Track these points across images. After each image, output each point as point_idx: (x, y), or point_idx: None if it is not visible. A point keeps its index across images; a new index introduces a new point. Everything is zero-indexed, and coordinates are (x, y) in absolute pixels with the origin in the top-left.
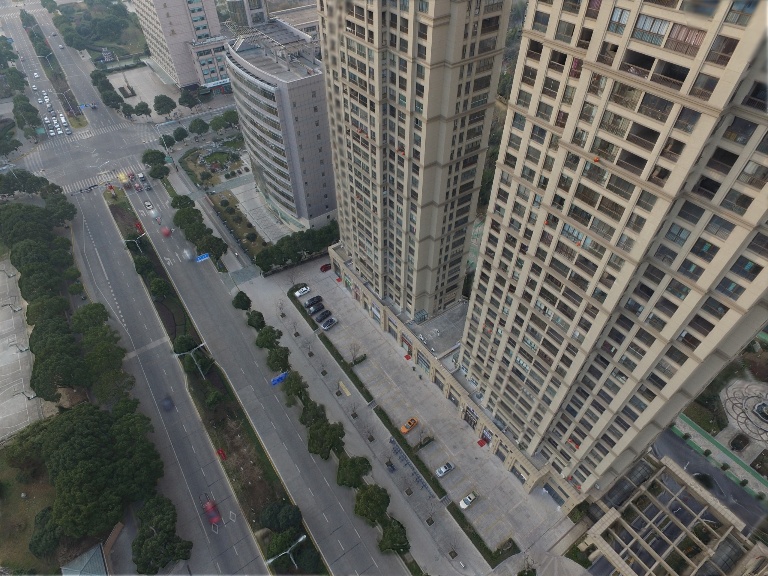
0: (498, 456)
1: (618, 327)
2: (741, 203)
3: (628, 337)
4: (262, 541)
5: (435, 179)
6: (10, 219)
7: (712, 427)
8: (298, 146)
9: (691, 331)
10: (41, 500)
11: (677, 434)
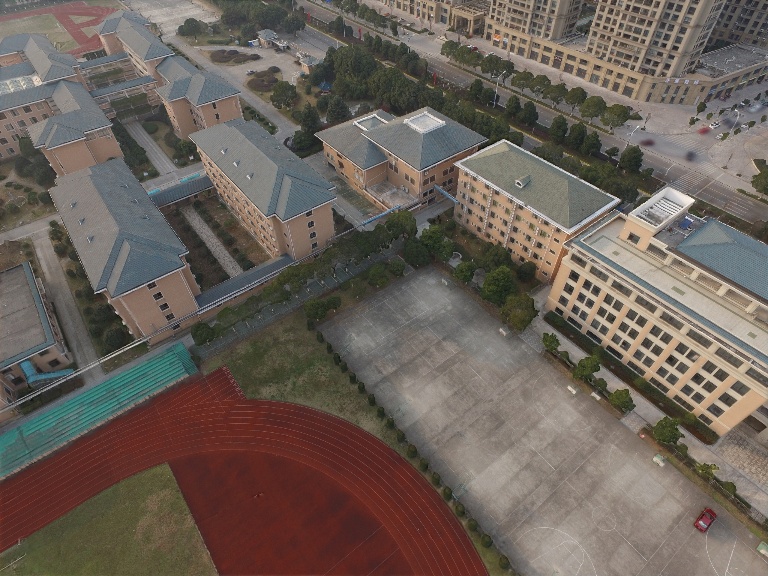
0: None
1: None
2: None
3: None
4: None
5: None
6: None
7: None
8: None
9: None
10: None
11: None
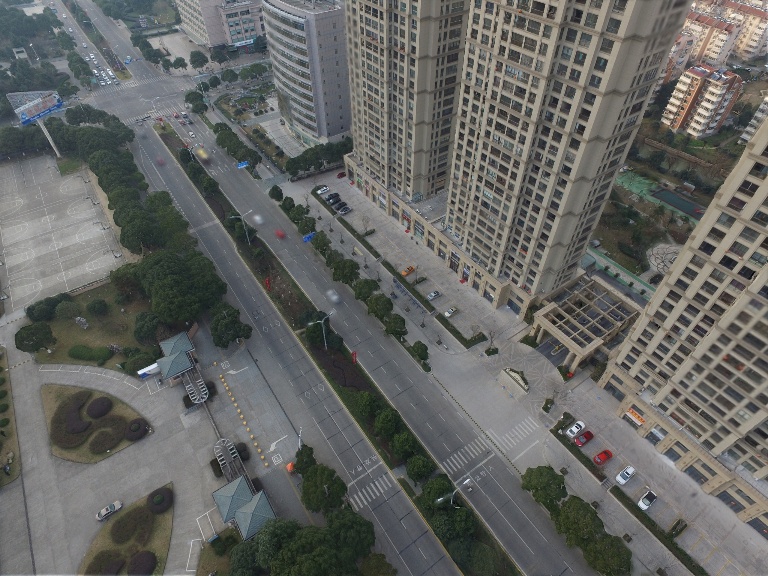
0: (474, 288)
1: (542, 137)
2: (593, 21)
3: (548, 141)
4: (300, 336)
5: (427, 70)
6: (86, 136)
7: (637, 270)
8: (321, 70)
9: (580, 122)
10: (136, 314)
11: (610, 274)
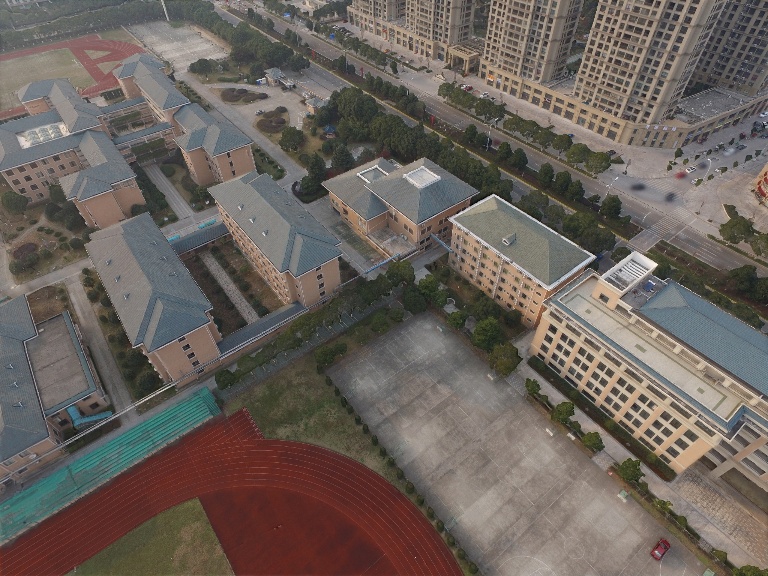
0: (422, 55)
1: None
2: None
3: None
4: None
5: None
6: (189, 2)
7: None
8: None
9: None
10: (245, 69)
11: None
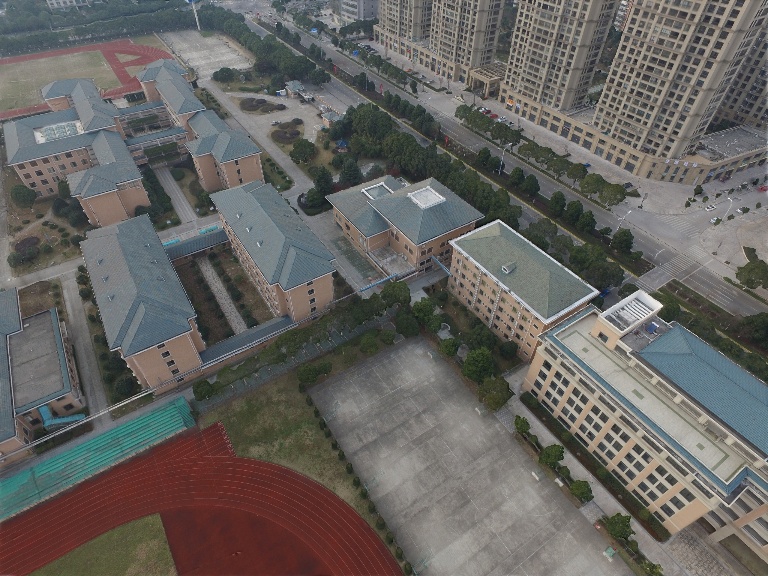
0: (443, 76)
1: None
2: None
3: None
4: None
5: None
6: (221, 13)
7: None
8: None
9: None
10: (267, 80)
11: None
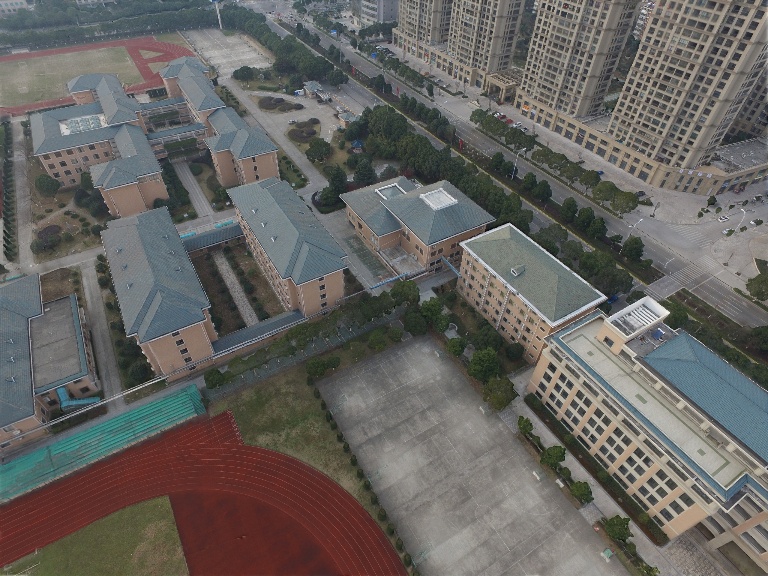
0: (460, 80)
1: None
2: None
3: None
4: None
5: None
6: (243, 13)
7: None
8: None
9: None
10: None
11: None
